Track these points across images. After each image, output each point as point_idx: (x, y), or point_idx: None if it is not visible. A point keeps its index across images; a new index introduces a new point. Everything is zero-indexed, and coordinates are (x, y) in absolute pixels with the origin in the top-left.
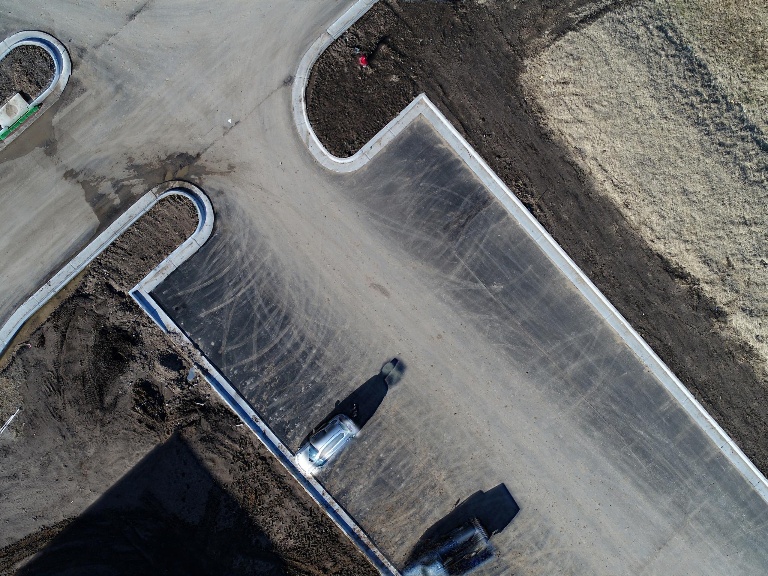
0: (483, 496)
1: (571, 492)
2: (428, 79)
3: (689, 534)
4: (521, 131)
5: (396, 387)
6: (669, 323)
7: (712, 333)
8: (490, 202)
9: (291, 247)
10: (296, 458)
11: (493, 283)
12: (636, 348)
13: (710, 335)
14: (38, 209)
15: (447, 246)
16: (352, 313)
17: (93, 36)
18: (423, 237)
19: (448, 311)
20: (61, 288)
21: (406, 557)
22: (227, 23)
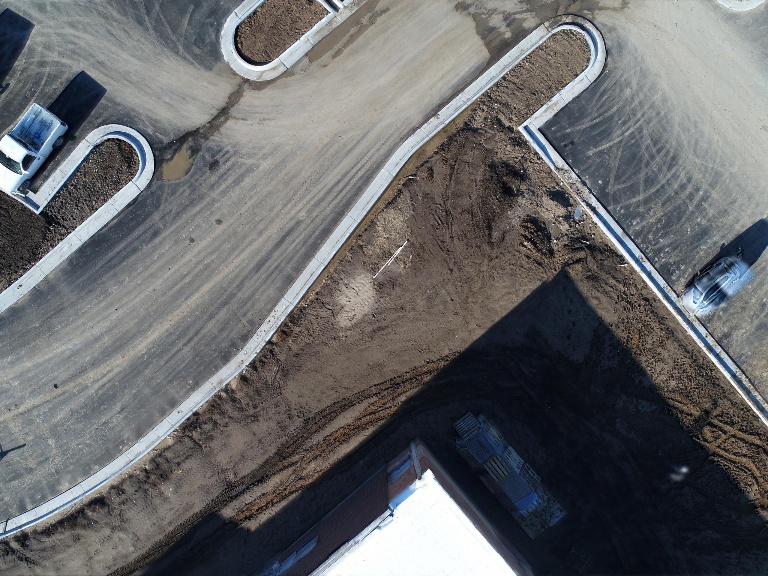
0: None
1: None
2: None
3: None
4: None
5: None
6: None
7: None
8: None
9: (683, 86)
10: (681, 299)
11: None
12: None
13: None
14: (428, 40)
15: None
16: (741, 155)
17: None
18: None
19: None
20: (450, 121)
21: None
22: None
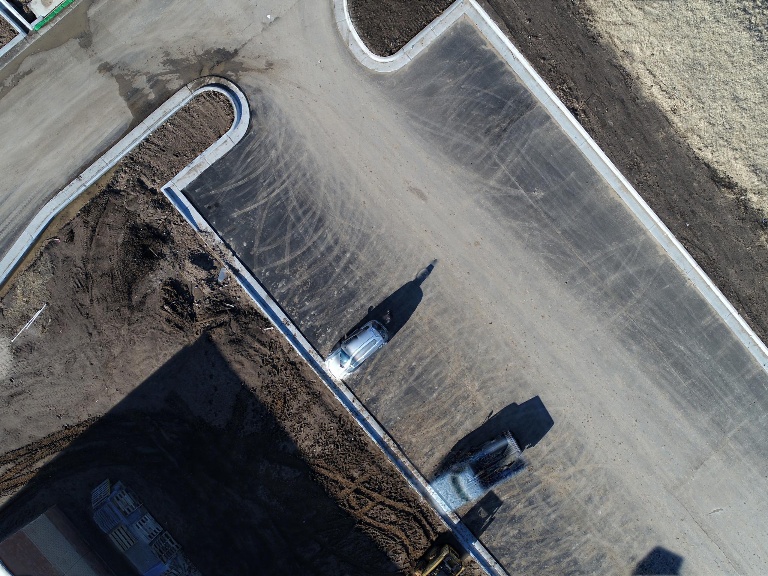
0: (517, 409)
1: (607, 407)
2: None
3: (728, 454)
4: (567, 33)
5: (431, 294)
6: (714, 235)
7: (758, 246)
8: (533, 106)
9: (328, 148)
10: (327, 363)
11: (534, 190)
12: (679, 260)
13: (756, 248)
14: (71, 102)
15: (488, 150)
16: (388, 217)
17: None
18: (463, 141)
19: (487, 217)
20: (92, 183)
21: (436, 468)
22: None
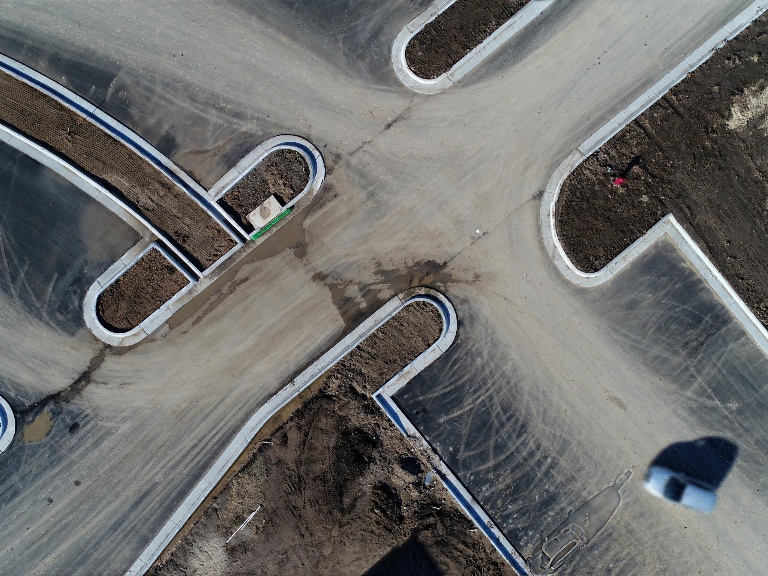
0: None
1: None
2: (676, 200)
3: None
4: (765, 255)
5: (628, 499)
6: None
7: None
8: (730, 322)
9: (532, 357)
10: (528, 565)
11: (729, 401)
12: None
13: None
14: (285, 309)
15: (685, 363)
16: (588, 424)
17: (348, 143)
18: (662, 353)
19: (683, 427)
20: (305, 388)
21: None
22: (480, 136)
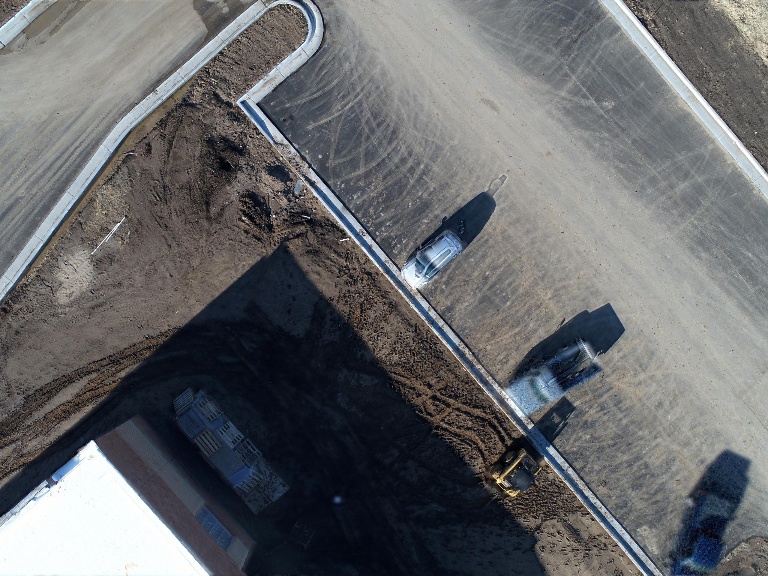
0: (589, 316)
1: (677, 314)
2: None
3: None
4: None
5: (504, 204)
6: None
7: None
8: (604, 17)
9: (401, 60)
10: (402, 273)
11: (604, 100)
12: (747, 168)
13: None
14: (145, 16)
15: (559, 61)
16: (461, 128)
17: None
18: (535, 52)
19: (558, 128)
20: (168, 97)
21: (510, 375)
22: None
